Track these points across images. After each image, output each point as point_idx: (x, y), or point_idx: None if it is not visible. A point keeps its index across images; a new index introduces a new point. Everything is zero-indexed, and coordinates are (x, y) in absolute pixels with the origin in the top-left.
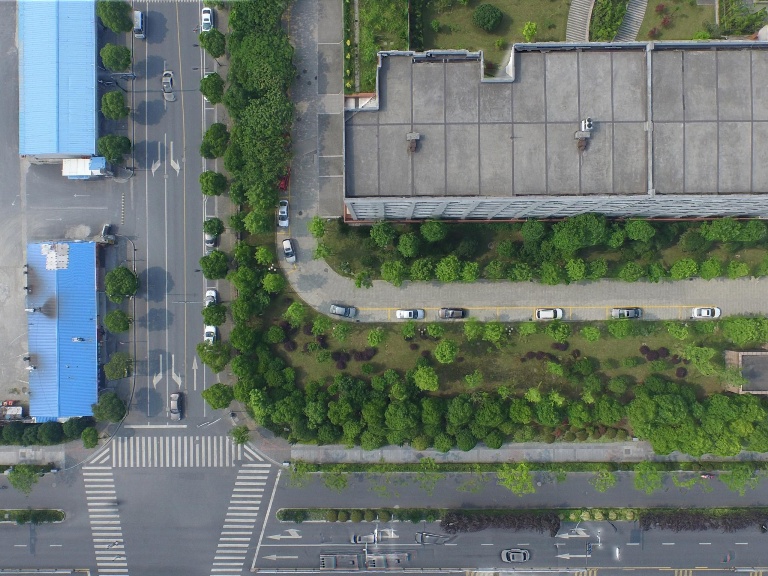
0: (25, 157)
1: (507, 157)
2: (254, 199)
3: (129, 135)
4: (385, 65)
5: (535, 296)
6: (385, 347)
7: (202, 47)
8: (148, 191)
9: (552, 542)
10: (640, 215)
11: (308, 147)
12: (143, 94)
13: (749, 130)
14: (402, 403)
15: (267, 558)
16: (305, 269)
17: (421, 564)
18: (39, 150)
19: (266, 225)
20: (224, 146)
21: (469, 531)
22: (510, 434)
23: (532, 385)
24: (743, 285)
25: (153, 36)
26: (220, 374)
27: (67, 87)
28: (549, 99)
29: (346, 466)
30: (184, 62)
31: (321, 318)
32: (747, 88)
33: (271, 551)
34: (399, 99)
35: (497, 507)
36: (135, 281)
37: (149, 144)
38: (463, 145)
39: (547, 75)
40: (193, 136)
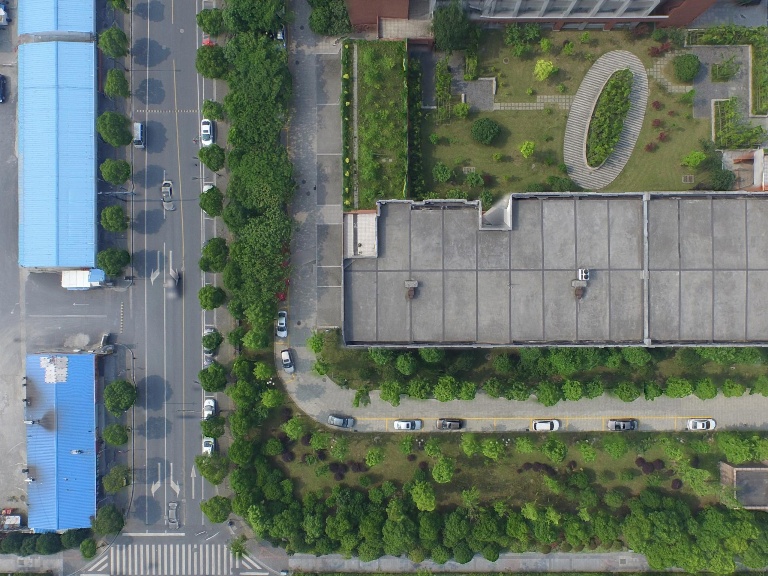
0: (24, 268)
1: (504, 304)
2: (253, 318)
3: (128, 244)
4: (384, 212)
5: (532, 407)
6: (383, 457)
7: (201, 162)
8: (147, 300)
9: None
10: None
11: (307, 257)
12: (142, 203)
13: (744, 279)
14: None
15: None
16: (303, 379)
17: None
18: (38, 263)
19: (265, 342)
20: (223, 262)
21: None
22: (507, 546)
23: (529, 499)
24: None
25: (153, 146)
26: (218, 485)
27: (67, 201)
28: (546, 246)
29: (343, 575)
30: (183, 172)
31: (319, 428)
32: (742, 237)
33: None
34: (398, 245)
35: None
36: (134, 395)
37: (148, 253)
38: (461, 292)
39: (544, 222)
40: (192, 245)
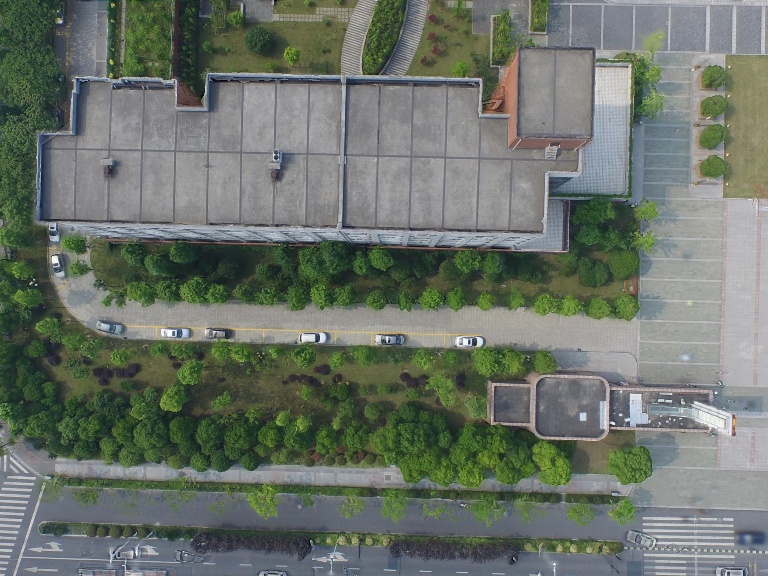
0: None
1: (202, 185)
2: (8, 215)
3: None
4: (85, 90)
5: (301, 319)
6: (149, 365)
7: None
8: None
9: (310, 565)
10: (391, 243)
11: None
12: None
13: (442, 166)
14: (150, 422)
15: (28, 570)
16: (75, 284)
17: None
18: None
19: (22, 241)
20: None
21: (221, 551)
22: (266, 456)
23: (287, 408)
24: (509, 315)
25: None
26: None
27: None
28: (245, 129)
29: (108, 482)
30: None
31: (88, 334)
32: (442, 124)
33: (32, 563)
34: (98, 124)
35: (256, 528)
36: None
37: None
38: (159, 172)
39: (244, 105)
40: None
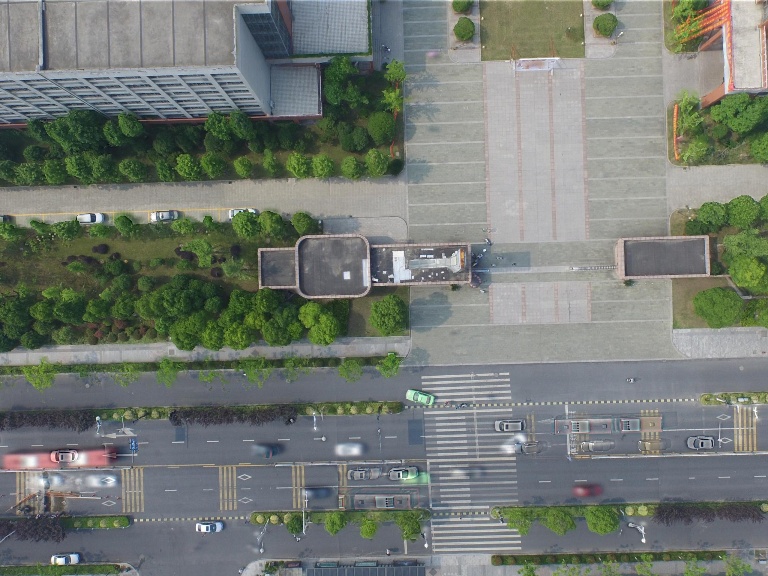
0: None
1: None
2: None
3: None
4: None
5: (79, 202)
6: None
7: None
8: None
9: (100, 442)
10: (146, 114)
11: None
12: None
13: (138, 8)
14: None
15: None
16: None
17: None
18: None
19: None
20: None
21: (6, 430)
22: (47, 335)
23: None
24: (280, 187)
25: None
26: None
27: None
28: None
29: None
30: None
31: None
32: None
33: None
34: None
35: (45, 409)
36: None
37: None
38: None
39: None
40: None
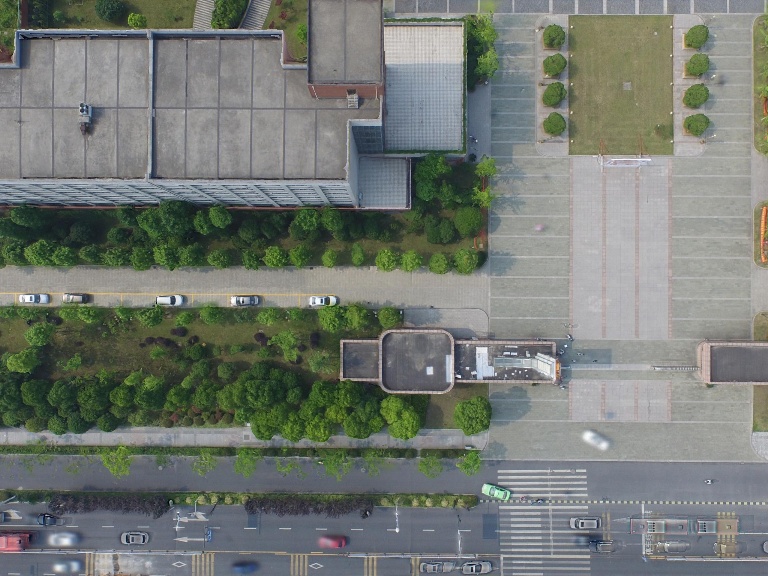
0: None
1: (15, 141)
2: None
3: None
4: None
5: (158, 283)
6: (9, 331)
7: None
8: None
9: (171, 525)
10: (235, 203)
11: None
12: None
13: (249, 117)
14: (2, 385)
15: None
16: None
17: (42, 545)
18: None
19: None
20: None
21: (79, 512)
22: (123, 418)
23: None
24: (362, 275)
25: None
26: None
27: None
28: (57, 85)
29: None
30: None
31: None
32: (248, 76)
33: None
34: None
35: (118, 490)
36: None
37: None
38: None
39: (56, 61)
40: None
